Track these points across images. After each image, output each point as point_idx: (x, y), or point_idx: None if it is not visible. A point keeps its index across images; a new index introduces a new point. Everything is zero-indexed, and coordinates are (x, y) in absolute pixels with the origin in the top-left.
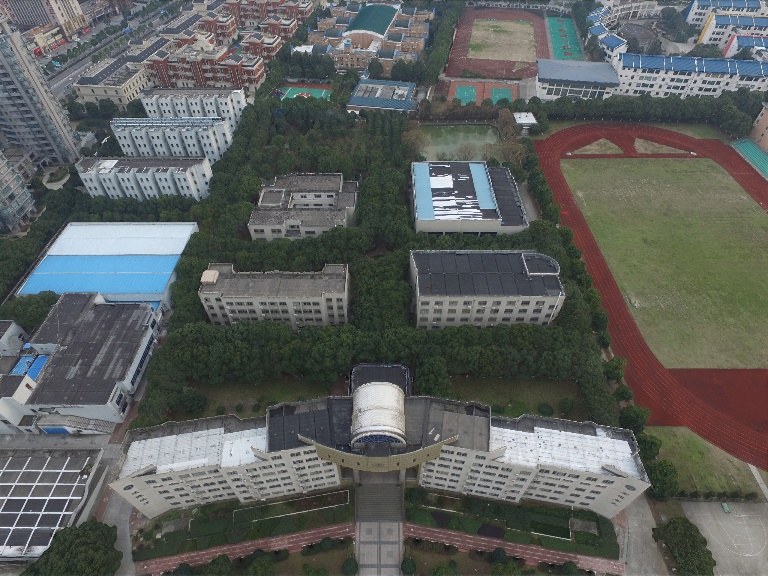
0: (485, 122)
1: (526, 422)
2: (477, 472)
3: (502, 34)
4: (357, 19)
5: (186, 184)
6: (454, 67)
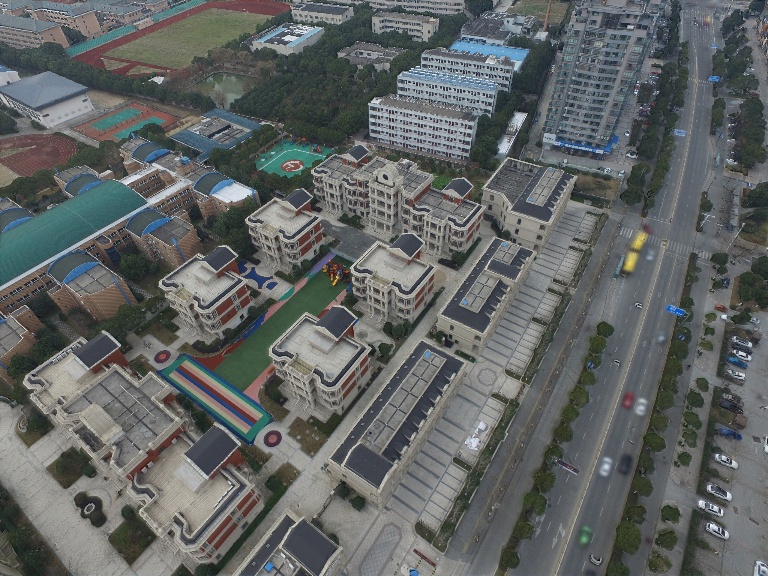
0: None
1: None
2: None
3: None
4: (72, 233)
5: None
6: None
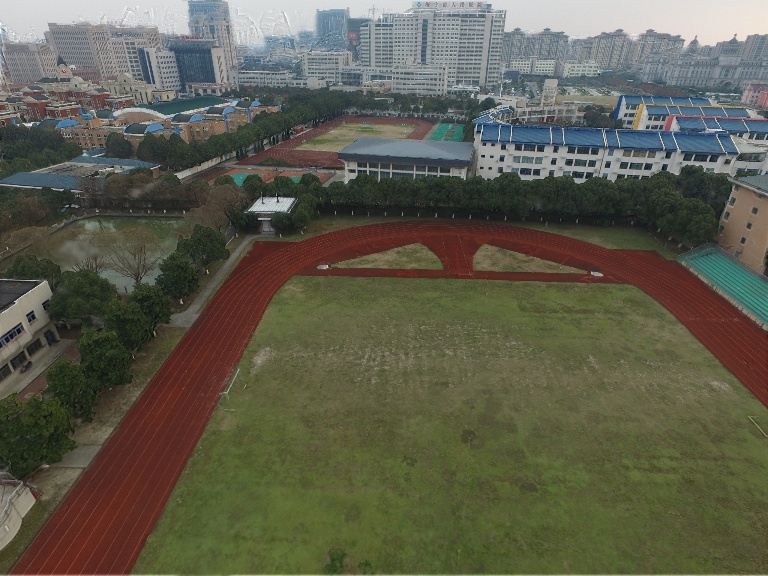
0: None
1: None
2: None
3: (367, 133)
4: None
5: None
6: (260, 156)
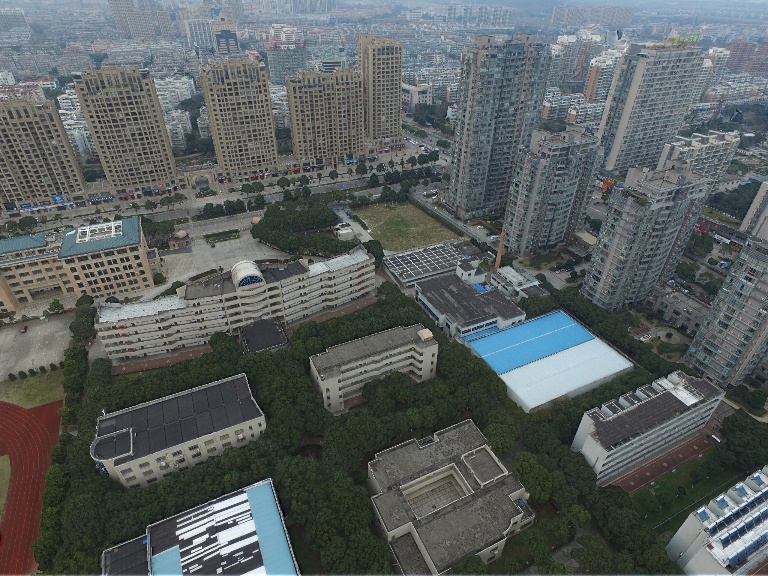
0: None
1: None
2: None
3: None
4: None
5: None
6: None
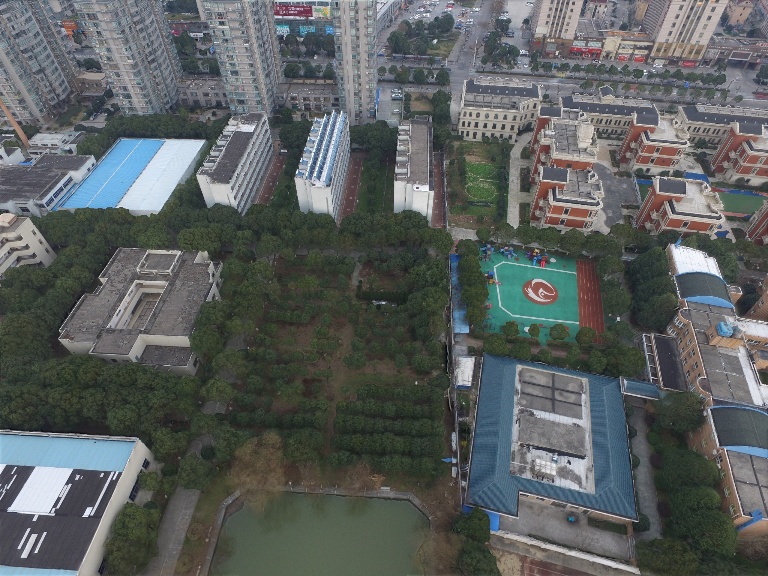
0: None
1: None
2: None
3: None
4: None
5: None
6: None
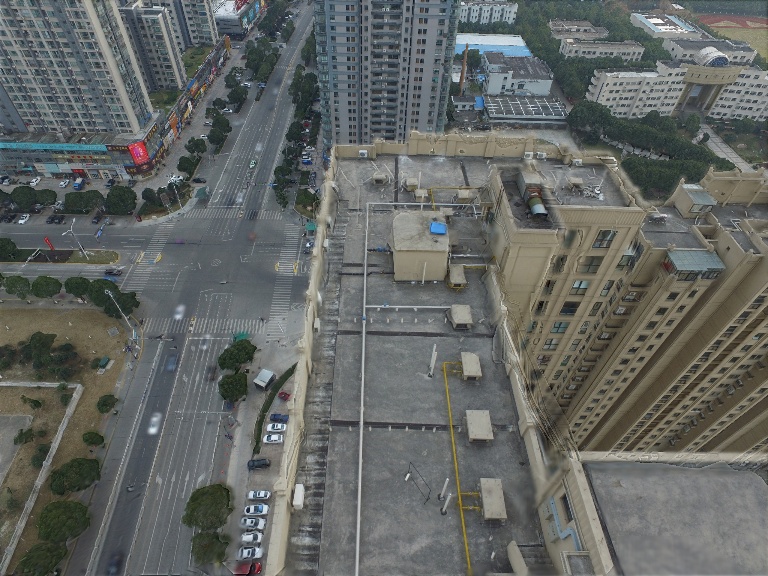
0: (646, 11)
1: (767, 75)
2: (747, 94)
3: None
4: None
5: (509, 15)
6: None
